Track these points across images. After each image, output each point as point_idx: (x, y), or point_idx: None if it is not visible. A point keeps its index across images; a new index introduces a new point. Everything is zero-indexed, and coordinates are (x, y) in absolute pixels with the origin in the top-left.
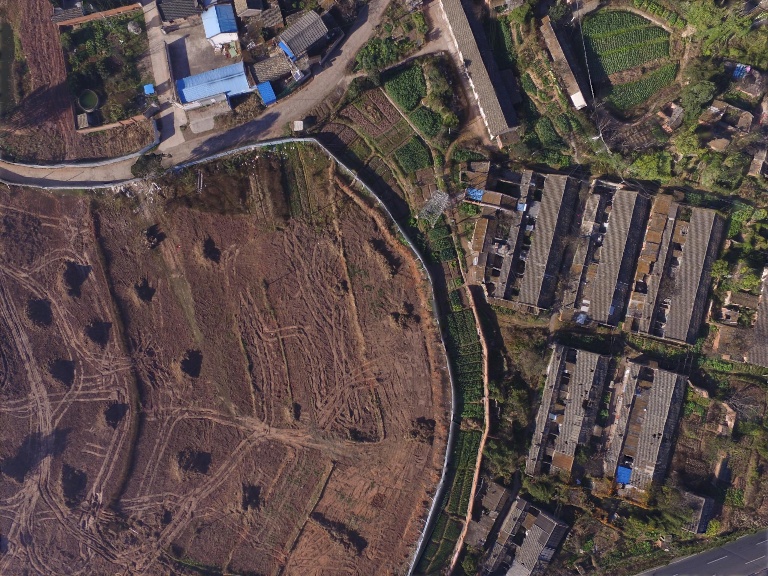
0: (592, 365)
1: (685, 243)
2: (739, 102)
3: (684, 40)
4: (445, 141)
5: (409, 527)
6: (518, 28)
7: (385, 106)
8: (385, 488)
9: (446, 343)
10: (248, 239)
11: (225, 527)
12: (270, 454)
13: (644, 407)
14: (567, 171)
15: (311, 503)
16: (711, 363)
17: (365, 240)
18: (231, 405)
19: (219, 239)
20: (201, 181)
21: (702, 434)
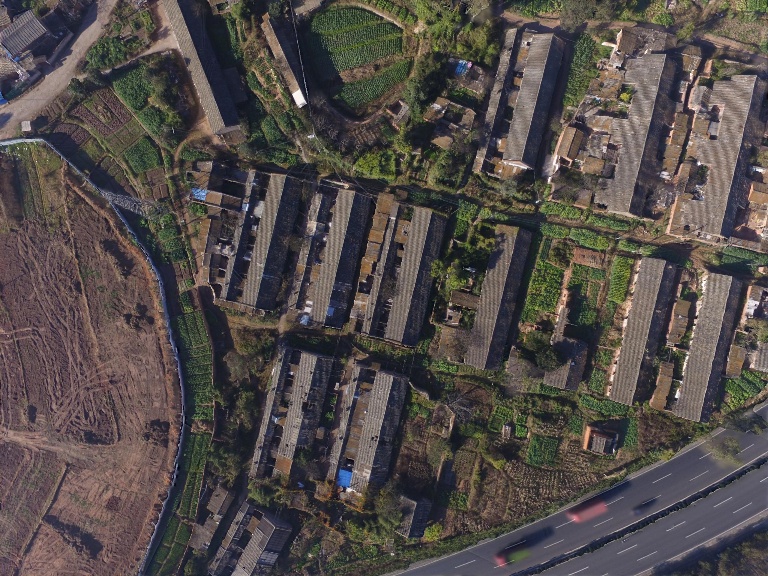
0: (311, 367)
1: (406, 243)
2: (465, 99)
3: (417, 36)
4: (172, 141)
5: (143, 530)
6: (241, 26)
7: (116, 106)
8: (120, 491)
9: (178, 345)
10: None
11: None
12: (8, 457)
13: (365, 409)
14: (295, 170)
15: (45, 506)
16: (437, 365)
17: (97, 241)
18: None
19: None
20: None
21: (427, 437)
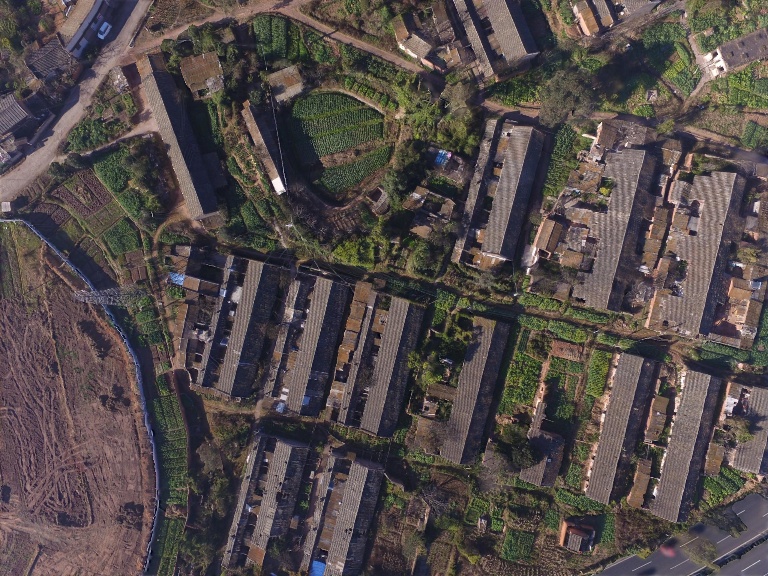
0: (286, 456)
1: (383, 332)
2: (445, 188)
3: (399, 122)
4: (151, 224)
5: None
6: (222, 111)
7: (96, 187)
8: (93, 574)
9: (154, 428)
10: None
11: None
12: None
13: (339, 500)
14: (274, 255)
15: None
16: (413, 455)
17: (75, 322)
18: None
19: None
20: None
21: (402, 528)
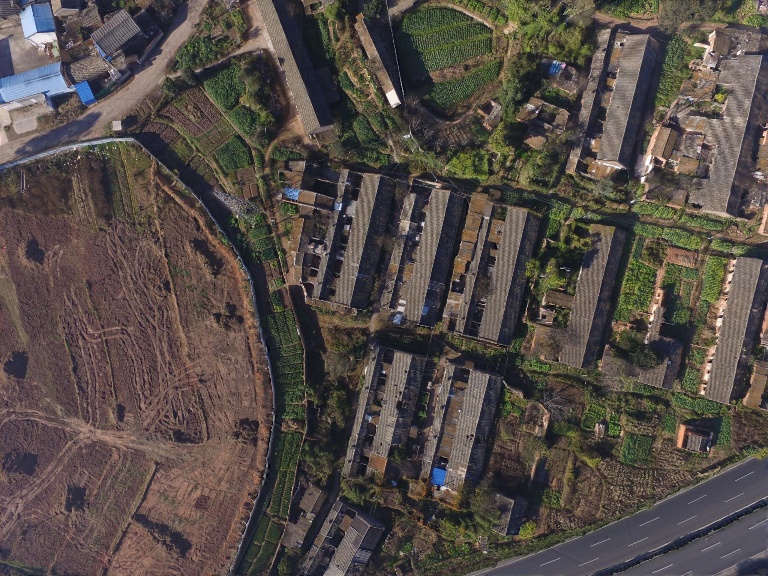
0: (406, 366)
1: (500, 242)
2: (558, 99)
3: (507, 37)
4: (263, 140)
5: (232, 529)
6: (334, 26)
7: (206, 105)
8: (209, 490)
9: (268, 344)
10: (72, 240)
11: (51, 529)
12: (96, 456)
13: (459, 408)
14: (387, 170)
15: (134, 505)
16: (529, 363)
17: (187, 240)
18: (57, 406)
19: (43, 240)
20: (24, 182)
21: (520, 435)
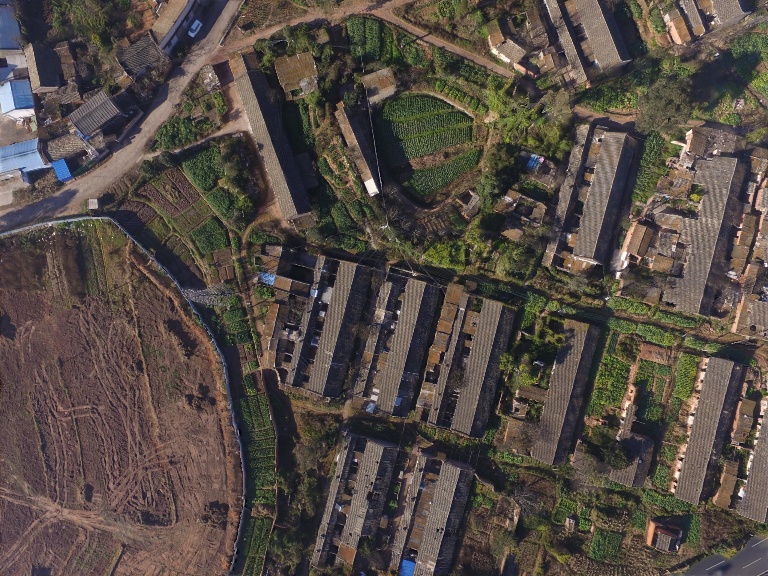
0: (377, 456)
1: (475, 334)
2: (535, 192)
3: (487, 126)
4: (240, 223)
5: None
6: (314, 112)
7: (184, 185)
8: (176, 573)
9: (240, 427)
10: (44, 316)
11: None
12: (62, 535)
13: (430, 500)
14: (364, 256)
15: None
16: (502, 455)
17: (161, 320)
18: (24, 484)
19: (15, 315)
20: None
21: (491, 527)
